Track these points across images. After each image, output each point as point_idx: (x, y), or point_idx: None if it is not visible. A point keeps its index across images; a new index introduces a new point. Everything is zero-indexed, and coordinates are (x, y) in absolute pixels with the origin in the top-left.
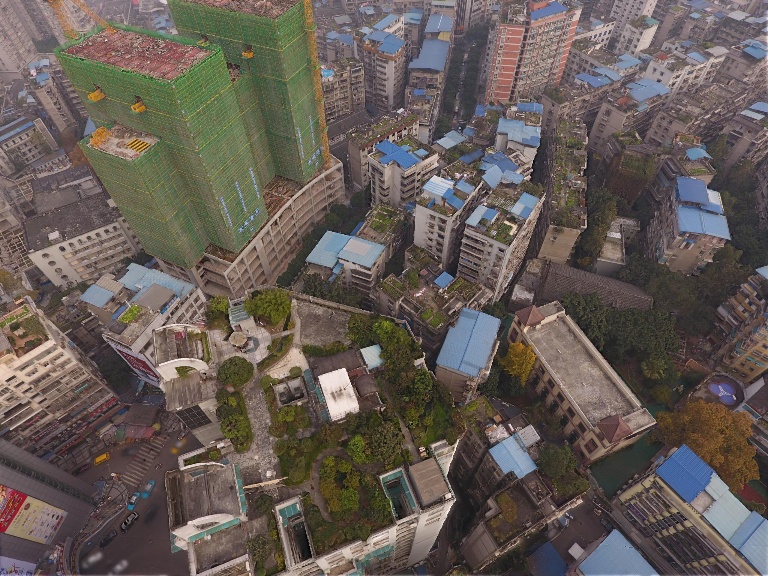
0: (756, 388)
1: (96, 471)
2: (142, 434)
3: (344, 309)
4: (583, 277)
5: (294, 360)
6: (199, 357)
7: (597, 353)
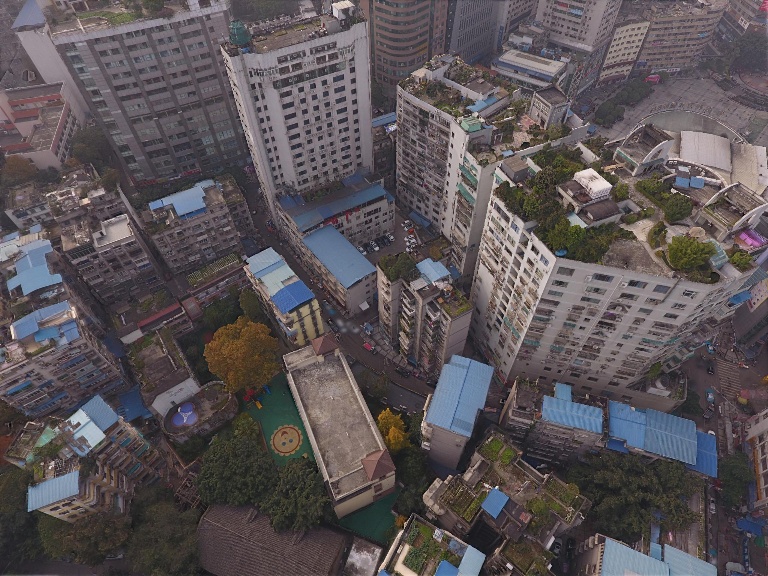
0: (161, 404)
1: (765, 371)
2: (751, 393)
3: (618, 272)
4: (278, 568)
5: (638, 233)
6: (717, 213)
7: (309, 428)
